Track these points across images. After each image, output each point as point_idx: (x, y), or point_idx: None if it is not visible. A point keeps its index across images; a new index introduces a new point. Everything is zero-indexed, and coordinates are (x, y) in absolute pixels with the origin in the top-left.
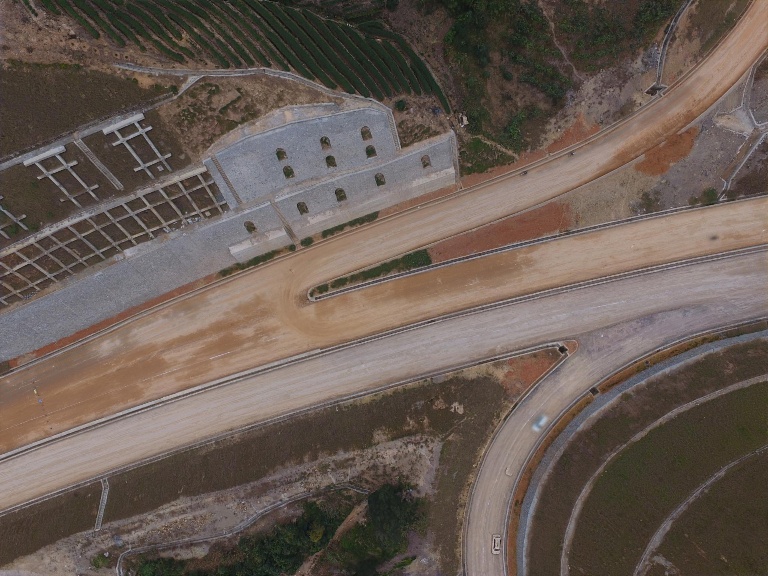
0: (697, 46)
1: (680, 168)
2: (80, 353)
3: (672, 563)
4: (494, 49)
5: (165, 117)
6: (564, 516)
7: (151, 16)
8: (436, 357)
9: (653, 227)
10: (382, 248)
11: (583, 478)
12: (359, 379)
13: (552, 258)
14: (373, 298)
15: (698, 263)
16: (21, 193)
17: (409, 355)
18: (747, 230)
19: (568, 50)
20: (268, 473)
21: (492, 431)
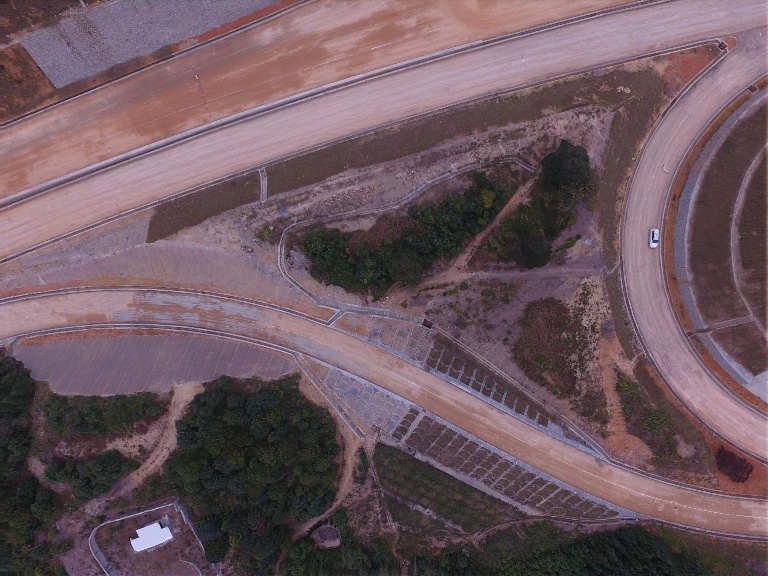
0: None
1: None
2: (241, 41)
3: None
4: None
5: None
6: (733, 189)
7: None
8: (596, 52)
9: None
10: None
11: (752, 152)
12: (519, 73)
13: None
14: None
15: None
16: None
17: (569, 50)
18: None
19: None
20: (438, 144)
21: (651, 125)
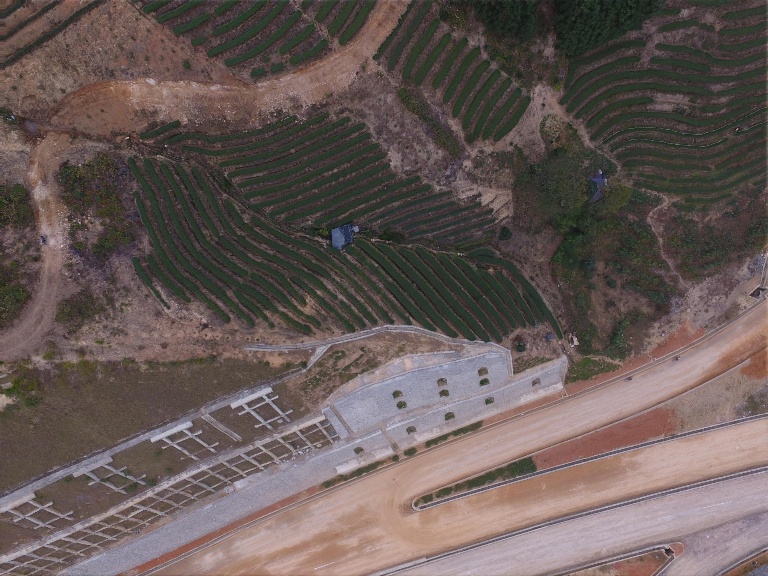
0: None
1: None
2: (182, 567)
3: None
4: (599, 259)
5: (292, 386)
6: None
7: (275, 284)
8: (542, 562)
9: (758, 428)
10: (486, 456)
11: None
12: None
13: (657, 461)
14: (477, 505)
15: None
16: (144, 460)
17: (514, 560)
18: None
19: (675, 262)
20: None
21: None
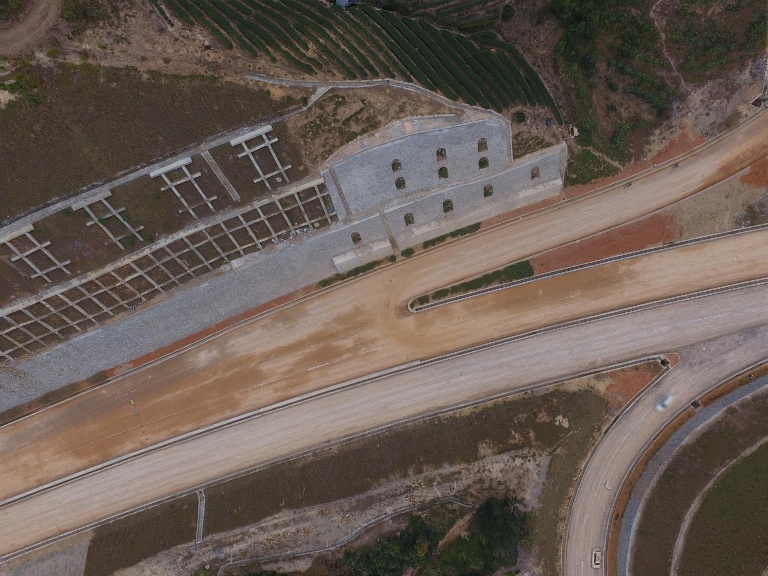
0: None
1: None
2: (177, 363)
3: None
4: (601, 59)
5: (292, 129)
6: (672, 531)
7: (278, 26)
8: (536, 369)
9: (757, 239)
10: (483, 259)
11: (692, 493)
12: (458, 391)
13: (654, 270)
14: (473, 309)
15: None
16: (143, 204)
17: (509, 367)
18: None
19: (677, 61)
20: (373, 486)
21: (593, 444)
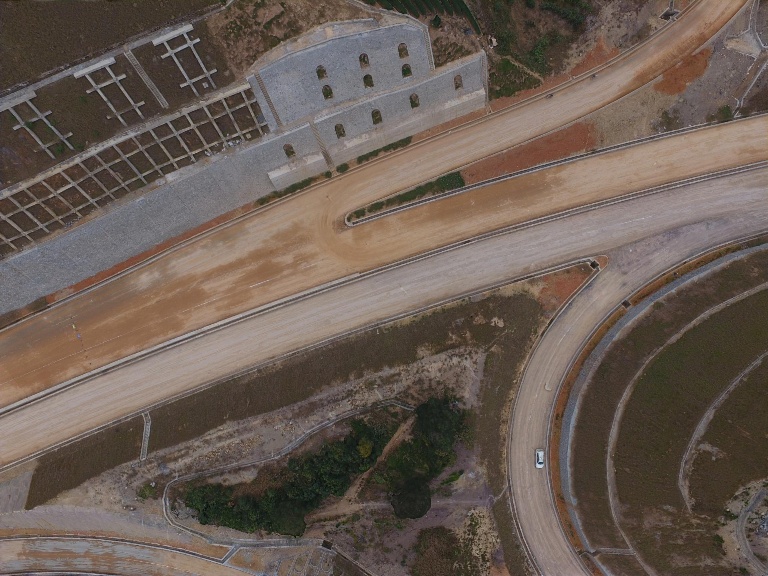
0: None
1: (696, 87)
2: (118, 286)
3: (718, 448)
4: None
5: (213, 29)
6: (607, 421)
7: None
8: (472, 277)
9: (673, 145)
10: (416, 172)
11: (623, 382)
12: (398, 302)
13: (580, 177)
14: (409, 221)
15: (717, 177)
16: (69, 108)
17: (446, 276)
18: (761, 145)
19: None
20: (315, 393)
21: (530, 347)
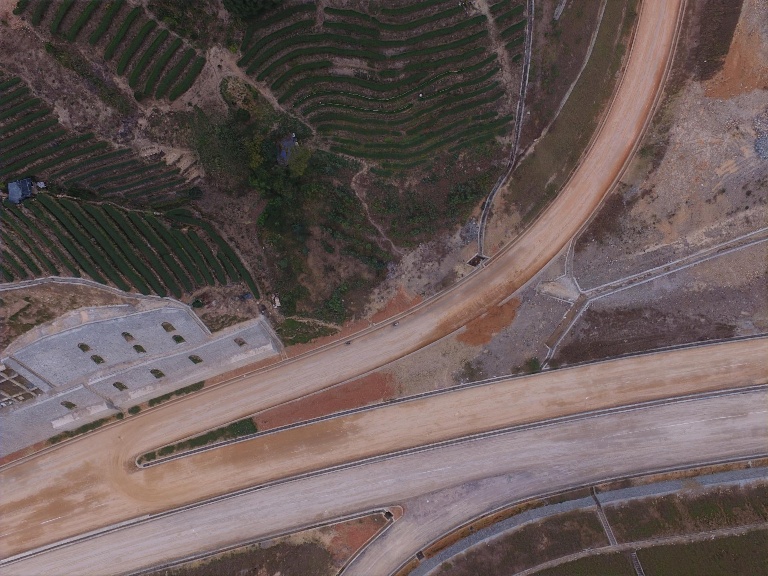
0: (517, 218)
1: (502, 338)
2: None
3: None
4: (313, 224)
5: None
6: None
7: None
8: (264, 522)
9: (477, 395)
10: (209, 416)
11: None
12: (189, 543)
13: (378, 425)
14: (201, 464)
15: (522, 430)
16: None
17: (238, 520)
18: (571, 397)
19: (384, 228)
20: None
21: None
